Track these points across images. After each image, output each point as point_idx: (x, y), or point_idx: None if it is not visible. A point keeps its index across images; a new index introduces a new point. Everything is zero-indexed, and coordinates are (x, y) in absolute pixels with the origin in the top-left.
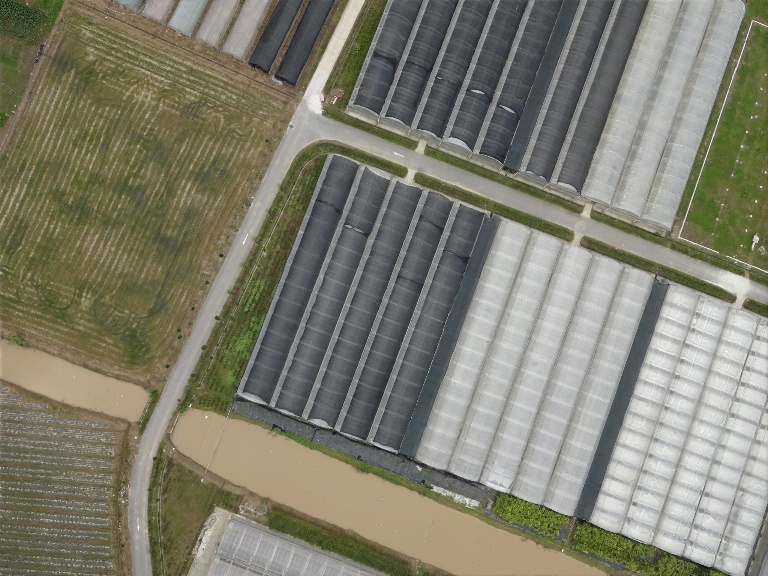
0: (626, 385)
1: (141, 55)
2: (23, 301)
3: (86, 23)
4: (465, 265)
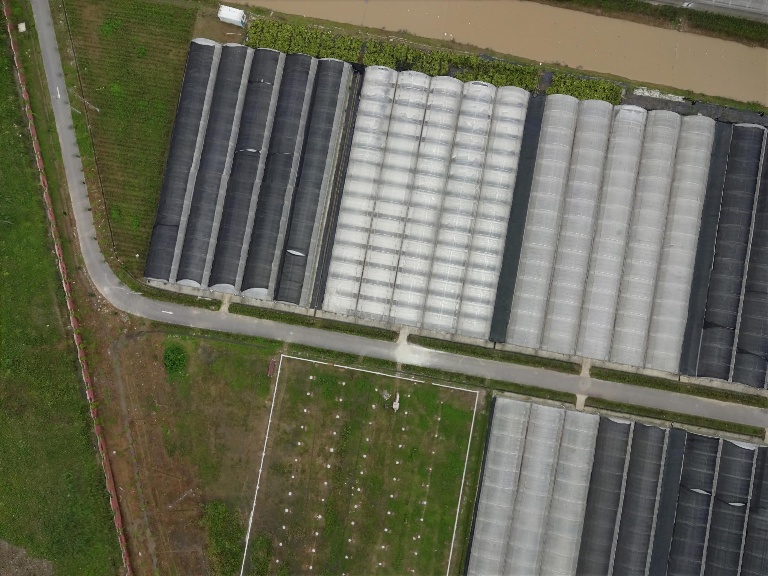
0: (511, 231)
1: None
2: None
3: None
4: (707, 320)
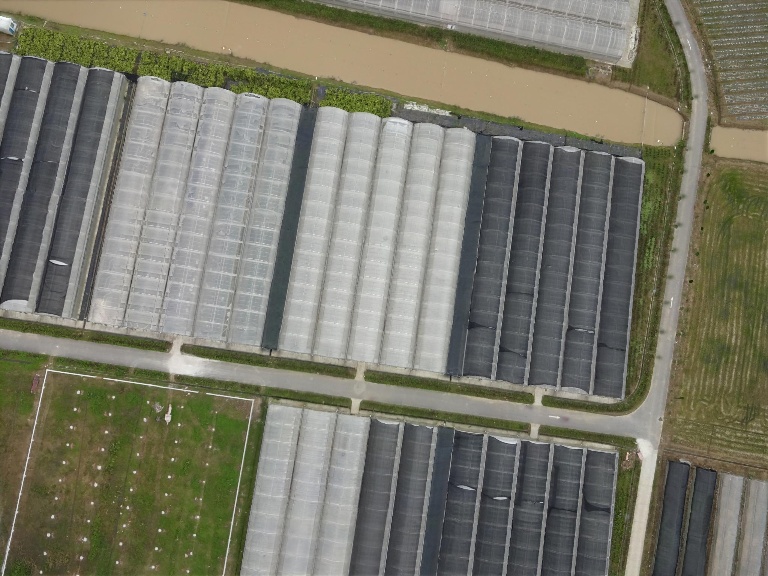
0: (285, 239)
1: None
2: None
3: None
4: (471, 321)
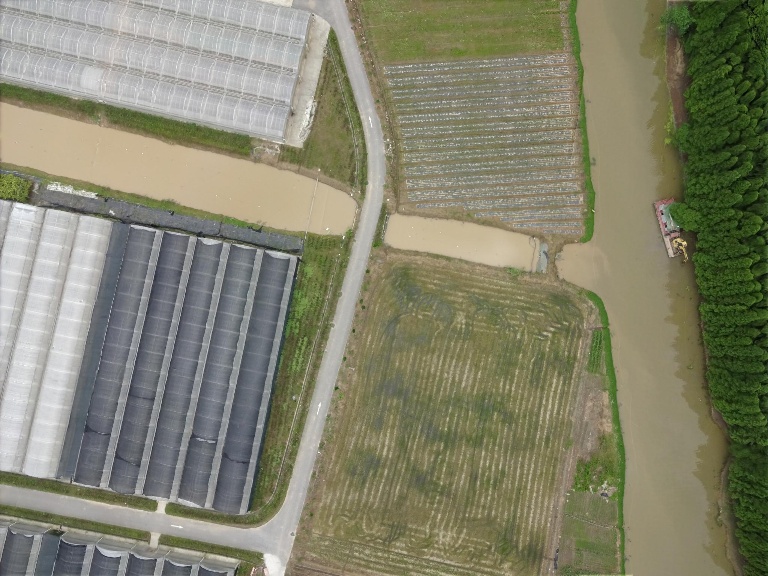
0: None
1: None
2: (519, 310)
3: None
4: (88, 423)
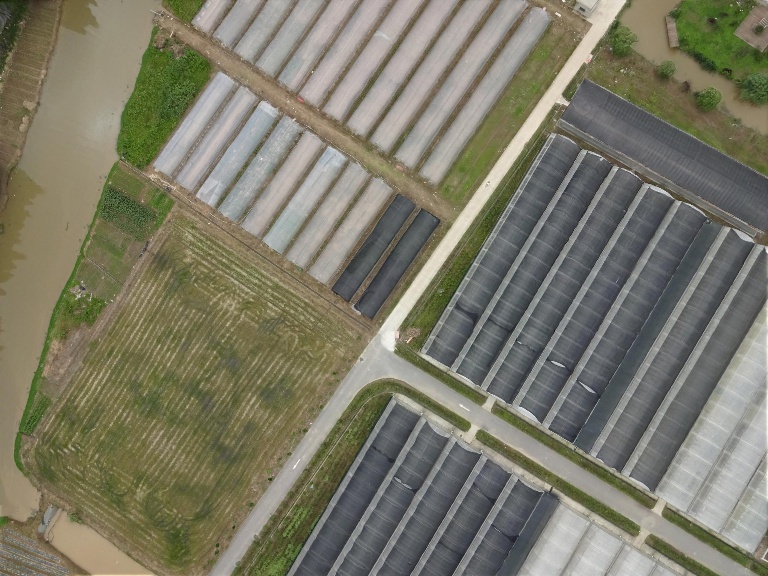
0: None
1: (233, 264)
2: (87, 480)
3: (190, 227)
4: (512, 543)
